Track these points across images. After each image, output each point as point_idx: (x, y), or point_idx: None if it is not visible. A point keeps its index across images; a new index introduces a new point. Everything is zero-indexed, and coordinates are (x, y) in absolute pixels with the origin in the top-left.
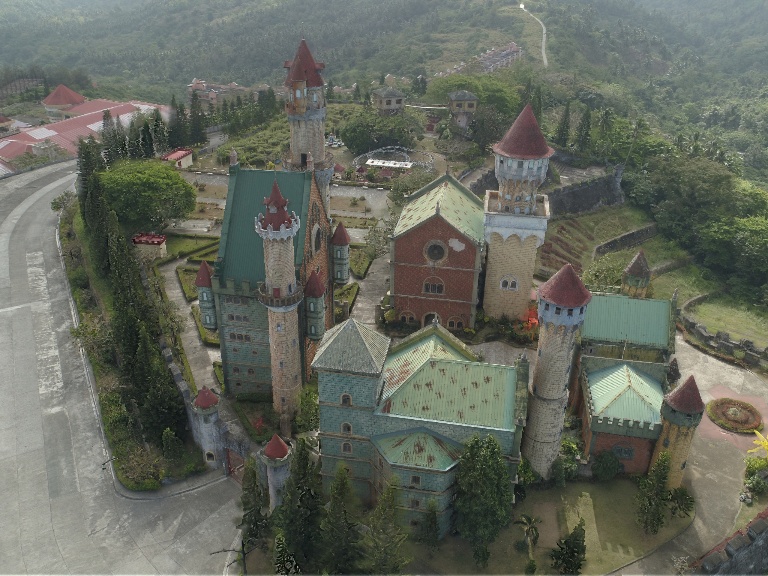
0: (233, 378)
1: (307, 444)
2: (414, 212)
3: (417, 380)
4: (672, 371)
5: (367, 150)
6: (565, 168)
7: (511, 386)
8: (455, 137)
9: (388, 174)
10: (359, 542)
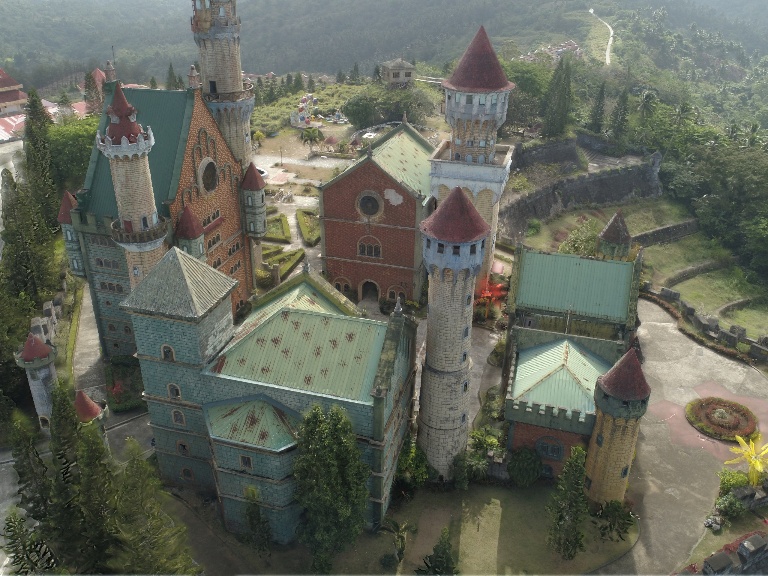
0: (109, 337)
1: None
2: None
3: (262, 334)
4: None
5: (372, 126)
6: (597, 156)
7: (379, 347)
8: None
9: None
10: None
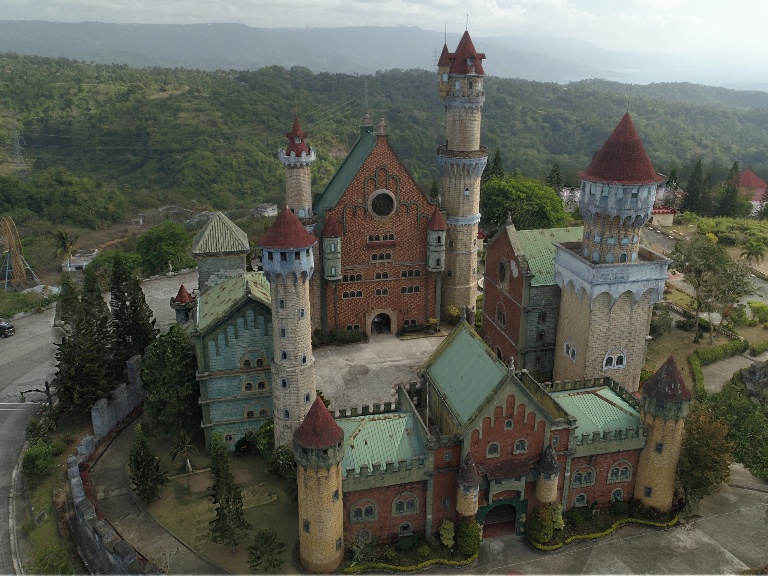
0: None
1: None
2: None
3: None
4: (461, 468)
5: None
6: None
7: None
8: None
9: None
10: None
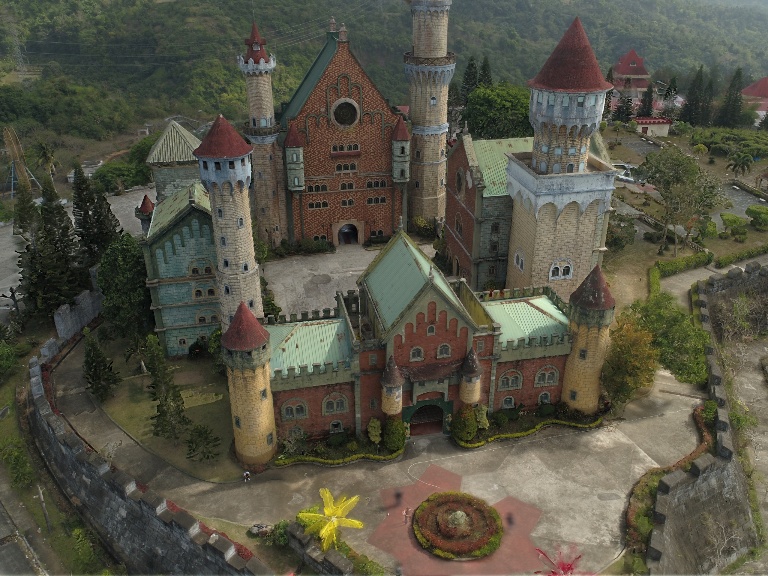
0: None
1: None
2: None
3: None
4: (384, 370)
5: None
6: None
7: None
8: None
9: None
10: None
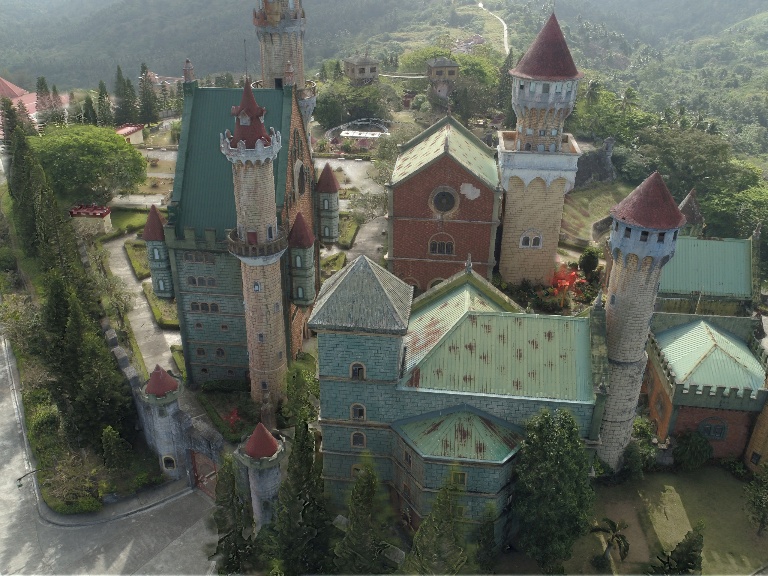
0: (197, 362)
1: None
2: (412, 159)
3: (453, 341)
4: None
5: (339, 124)
6: None
7: (582, 343)
8: (435, 109)
9: (366, 145)
10: (394, 572)
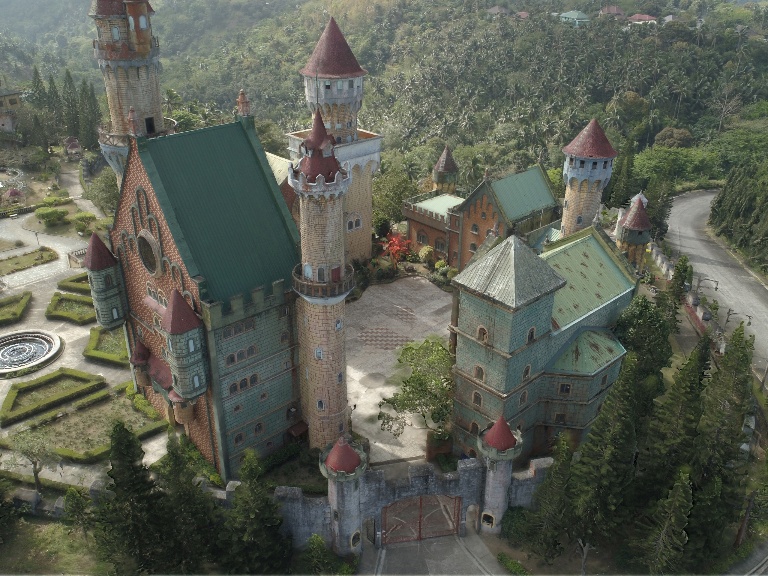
0: (236, 453)
1: (391, 460)
2: None
3: None
4: None
5: None
6: None
7: (602, 252)
8: (3, 146)
9: None
10: (697, 437)
